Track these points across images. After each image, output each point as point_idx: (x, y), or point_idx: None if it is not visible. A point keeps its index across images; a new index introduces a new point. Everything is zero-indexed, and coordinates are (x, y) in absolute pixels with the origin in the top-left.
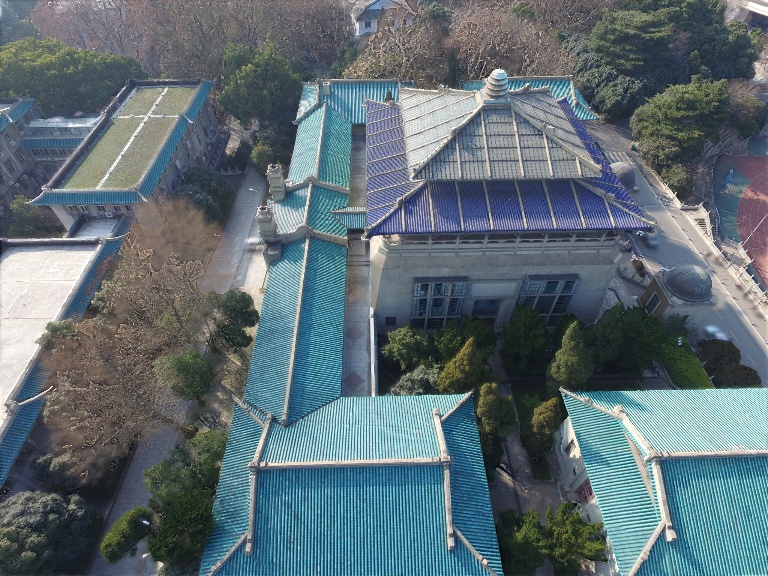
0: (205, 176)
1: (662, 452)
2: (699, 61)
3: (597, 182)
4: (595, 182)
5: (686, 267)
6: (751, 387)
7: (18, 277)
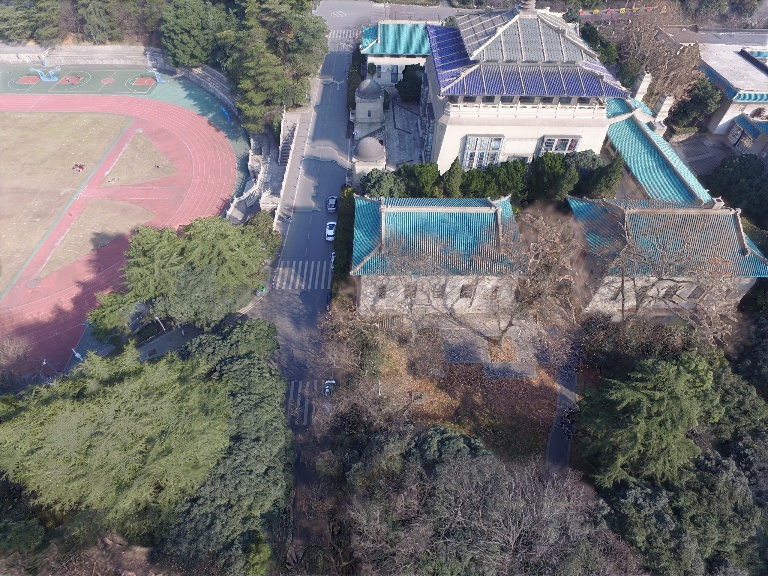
0: (757, 180)
1: (442, 21)
2: (6, 396)
3: (449, 33)
4: (451, 32)
5: (374, 83)
6: (358, 82)
7: (761, 83)
